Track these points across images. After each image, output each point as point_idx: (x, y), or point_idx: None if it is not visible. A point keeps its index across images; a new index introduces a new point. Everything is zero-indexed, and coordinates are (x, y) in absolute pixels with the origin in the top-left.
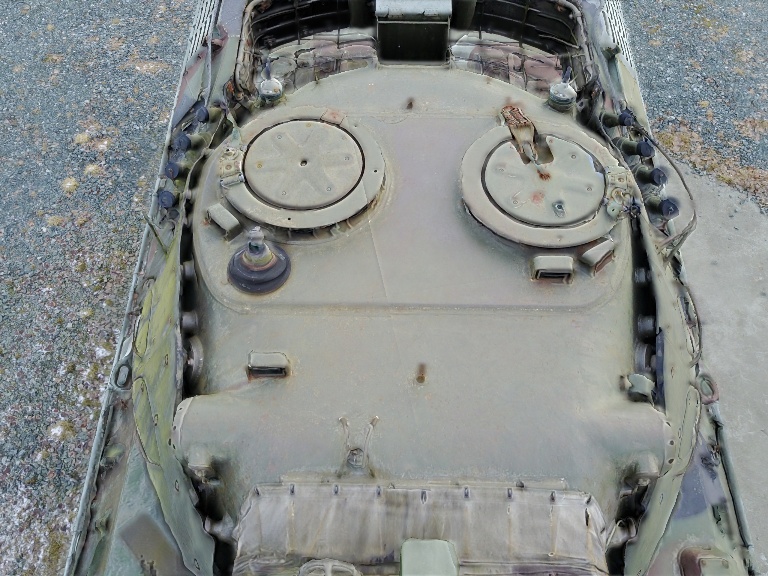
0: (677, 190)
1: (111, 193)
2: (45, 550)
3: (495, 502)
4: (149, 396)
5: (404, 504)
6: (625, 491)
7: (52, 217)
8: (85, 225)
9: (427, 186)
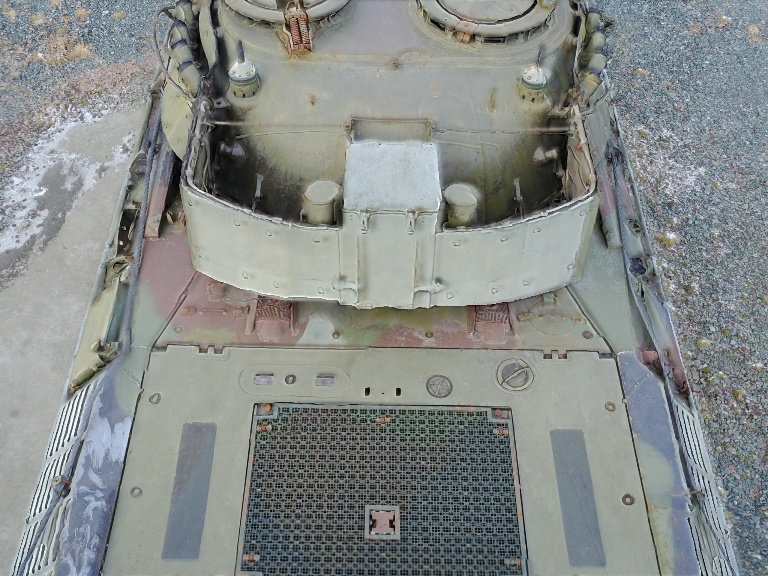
0: (2, 527)
1: (759, 499)
2: (637, 165)
3: None
4: None
5: None
6: None
7: None
8: (765, 451)
9: (382, 4)
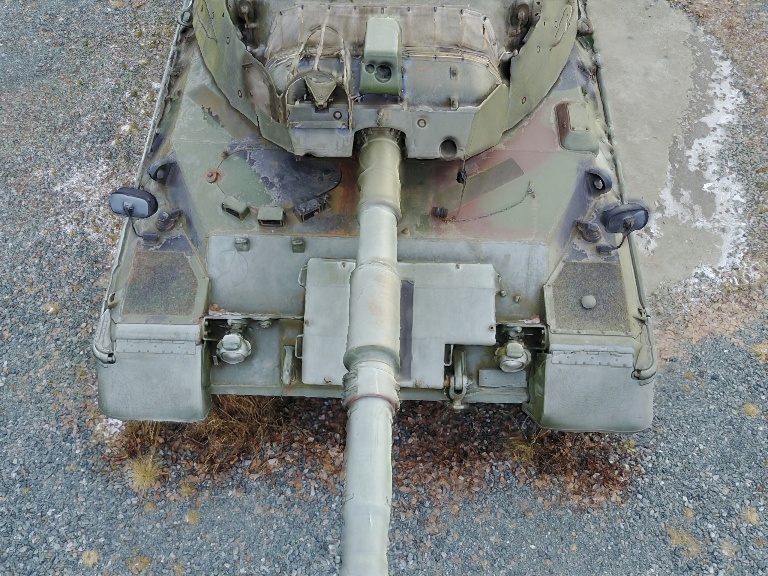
0: None
1: None
2: None
3: (426, 14)
4: (208, 5)
5: (371, 15)
6: (512, 31)
7: (115, 1)
8: (141, 8)
9: None
